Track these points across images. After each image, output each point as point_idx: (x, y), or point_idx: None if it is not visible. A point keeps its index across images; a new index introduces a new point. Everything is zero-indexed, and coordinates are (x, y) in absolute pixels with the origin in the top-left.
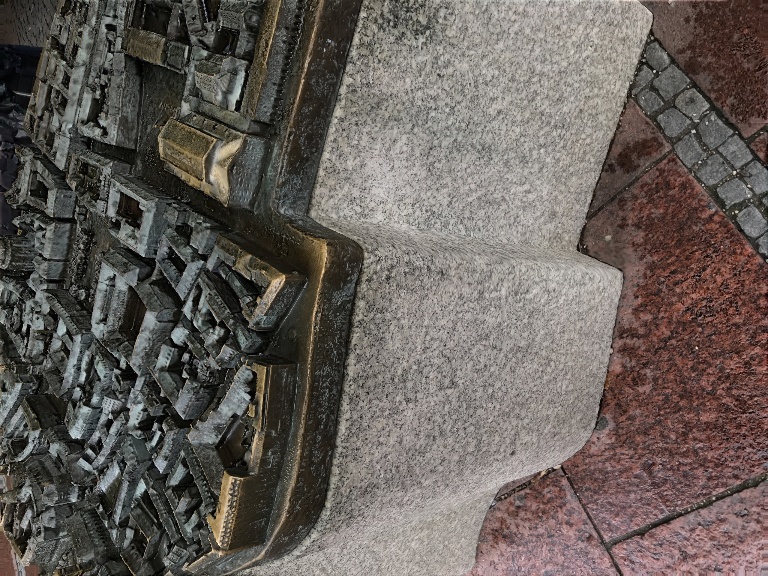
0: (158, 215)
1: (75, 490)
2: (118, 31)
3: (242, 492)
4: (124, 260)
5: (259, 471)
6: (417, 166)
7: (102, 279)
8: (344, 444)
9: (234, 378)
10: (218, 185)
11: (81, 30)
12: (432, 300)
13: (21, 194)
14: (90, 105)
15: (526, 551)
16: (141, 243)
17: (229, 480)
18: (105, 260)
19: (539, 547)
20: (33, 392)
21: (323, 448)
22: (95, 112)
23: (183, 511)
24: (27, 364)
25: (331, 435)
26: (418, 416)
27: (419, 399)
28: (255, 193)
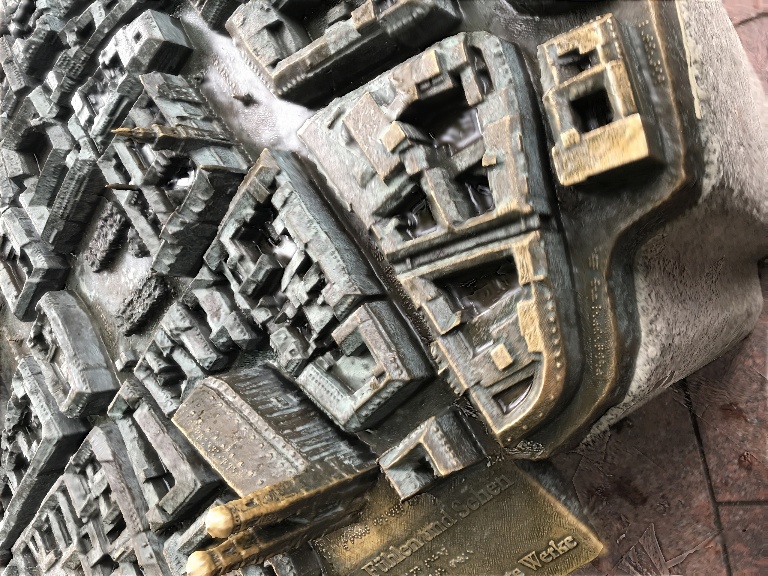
0: None
1: None
2: (0, 468)
3: None
4: None
5: None
6: None
7: None
8: None
9: None
10: None
11: (32, 547)
12: None
13: None
14: None
15: None
16: None
17: None
18: None
19: None
20: None
21: None
22: None
23: None
24: None
25: None
26: None
27: None
28: None
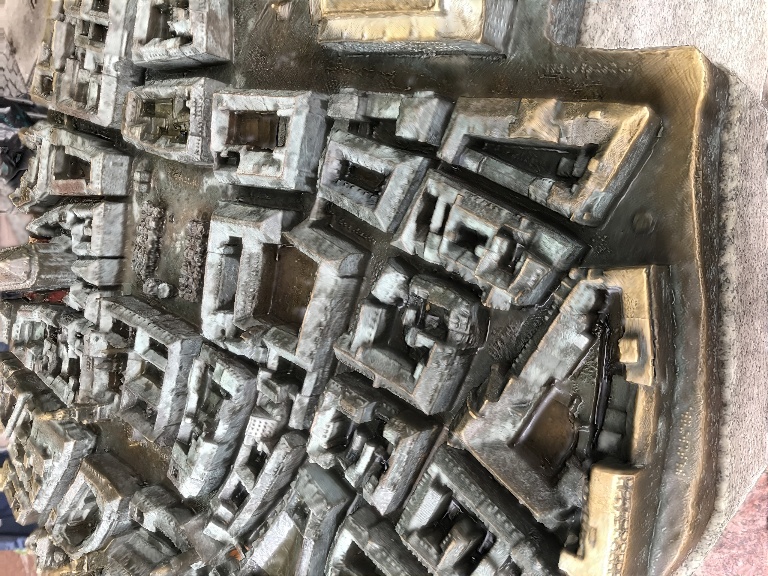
0: (311, 120)
1: (192, 575)
2: None
3: (634, 501)
4: (250, 209)
5: (648, 459)
6: (666, 6)
7: (213, 247)
8: (734, 398)
9: (558, 311)
10: (460, 10)
11: None
12: (765, 172)
13: (38, 185)
14: (149, 16)
15: (743, 553)
16: (289, 166)
17: (611, 483)
18: (217, 216)
19: (764, 545)
20: (88, 453)
21: (716, 408)
22: (156, 27)
23: (451, 566)
24: (92, 405)
25: (718, 385)
26: (765, 354)
27: (764, 327)
28: (509, 24)
